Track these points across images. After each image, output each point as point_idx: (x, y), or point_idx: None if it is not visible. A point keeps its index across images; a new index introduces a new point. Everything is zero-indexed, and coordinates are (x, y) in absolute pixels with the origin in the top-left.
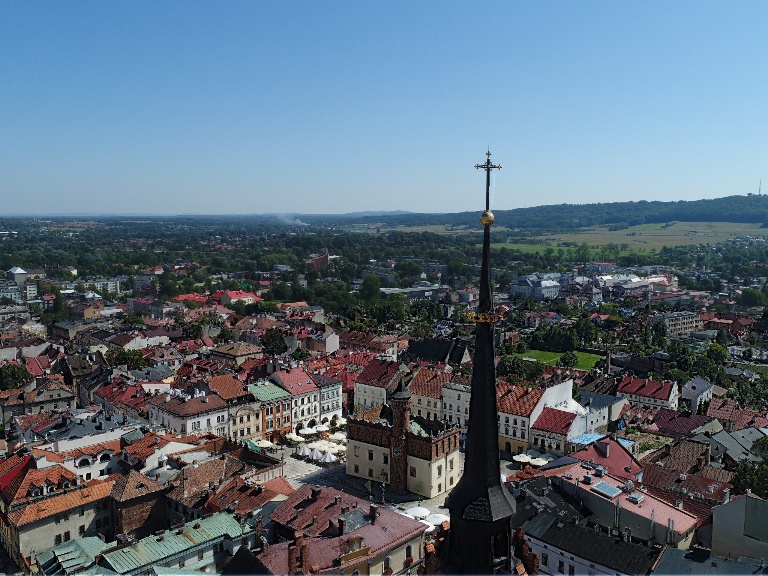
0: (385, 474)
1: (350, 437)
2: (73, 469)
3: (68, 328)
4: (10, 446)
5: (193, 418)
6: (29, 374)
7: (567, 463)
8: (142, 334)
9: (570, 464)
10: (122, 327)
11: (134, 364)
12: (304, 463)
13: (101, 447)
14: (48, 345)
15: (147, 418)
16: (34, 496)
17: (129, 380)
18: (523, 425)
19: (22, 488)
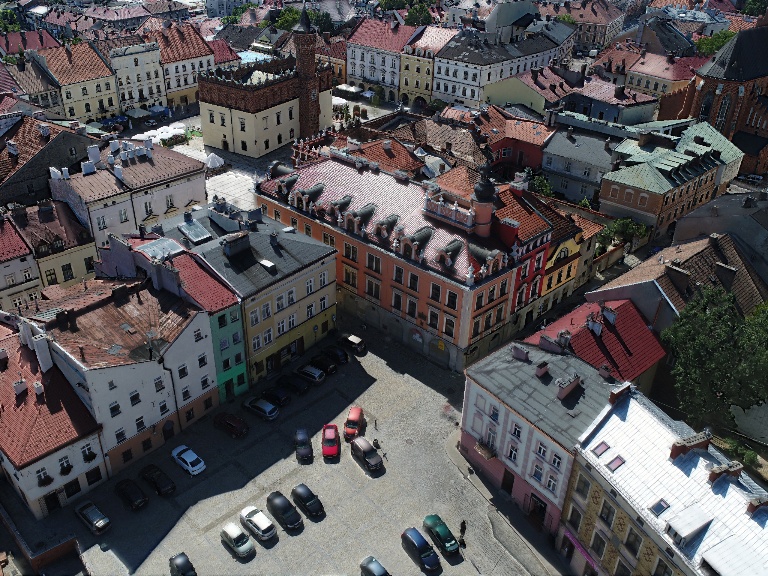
0: (292, 131)
1: (257, 110)
2: None
3: None
4: None
5: None
6: None
7: (420, 32)
8: None
9: (425, 31)
10: None
11: None
12: (208, 181)
13: None
14: None
15: (87, 240)
16: None
17: None
18: (209, 65)
19: None
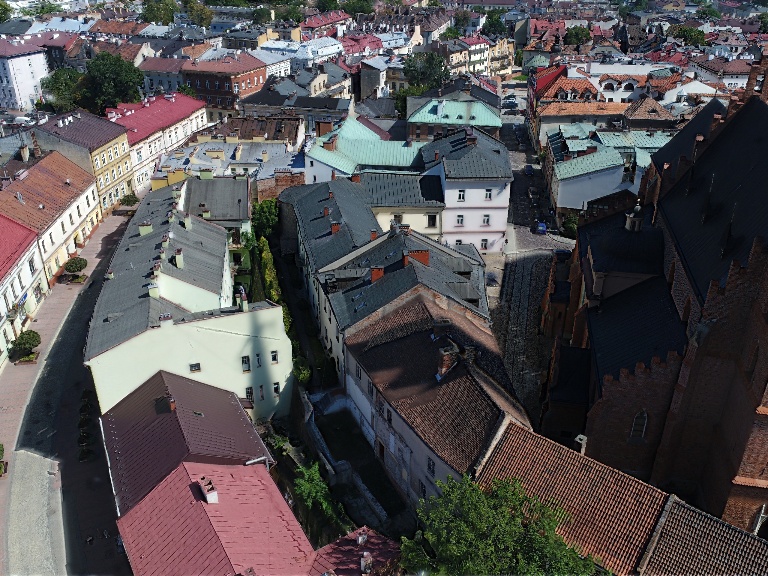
0: None
1: None
2: (597, 86)
3: (641, 16)
4: (551, 58)
5: (731, 78)
6: (591, 37)
7: None
8: (713, 24)
9: None
10: (695, 17)
11: (693, 43)
12: None
13: (628, 76)
14: (616, 22)
15: None
16: (560, 98)
17: (680, 47)
18: None
19: (552, 89)
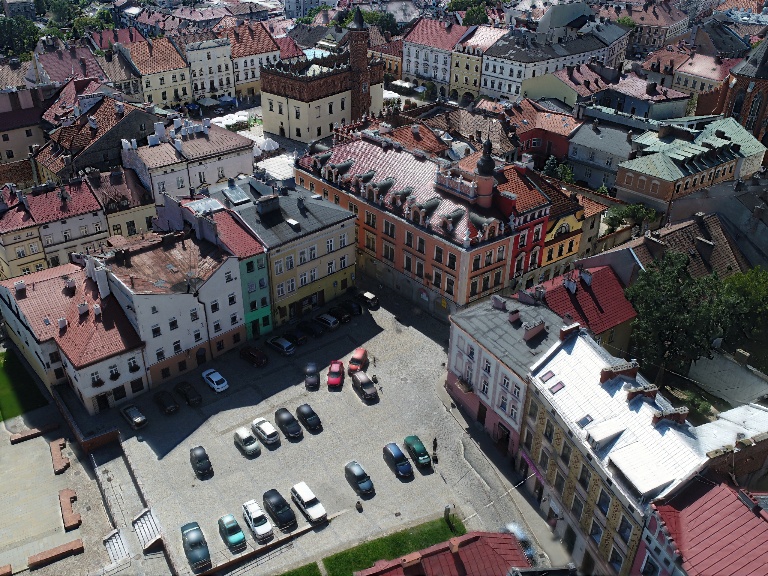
0: None
1: (311, 100)
2: None
3: None
4: None
5: None
6: None
7: (472, 31)
8: None
9: (477, 30)
10: None
11: None
12: (263, 162)
13: None
14: None
15: (148, 201)
16: None
17: None
18: (275, 60)
19: None
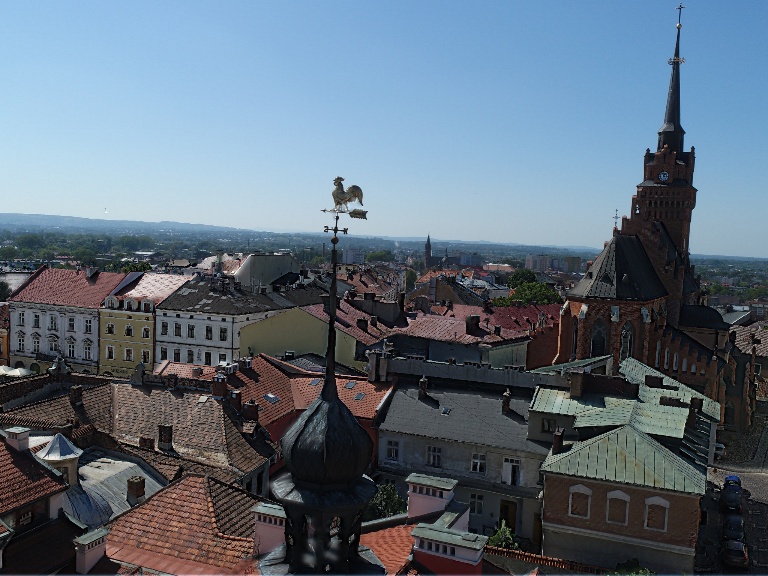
0: None
1: None
2: None
3: None
4: None
5: None
6: None
7: (134, 280)
8: None
9: (142, 278)
10: None
11: None
12: None
13: None
14: None
15: None
16: None
17: None
18: None
19: None
